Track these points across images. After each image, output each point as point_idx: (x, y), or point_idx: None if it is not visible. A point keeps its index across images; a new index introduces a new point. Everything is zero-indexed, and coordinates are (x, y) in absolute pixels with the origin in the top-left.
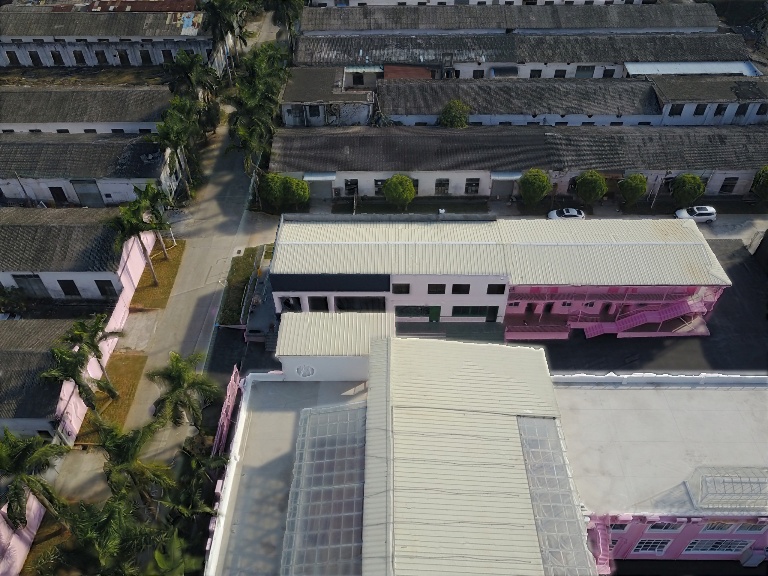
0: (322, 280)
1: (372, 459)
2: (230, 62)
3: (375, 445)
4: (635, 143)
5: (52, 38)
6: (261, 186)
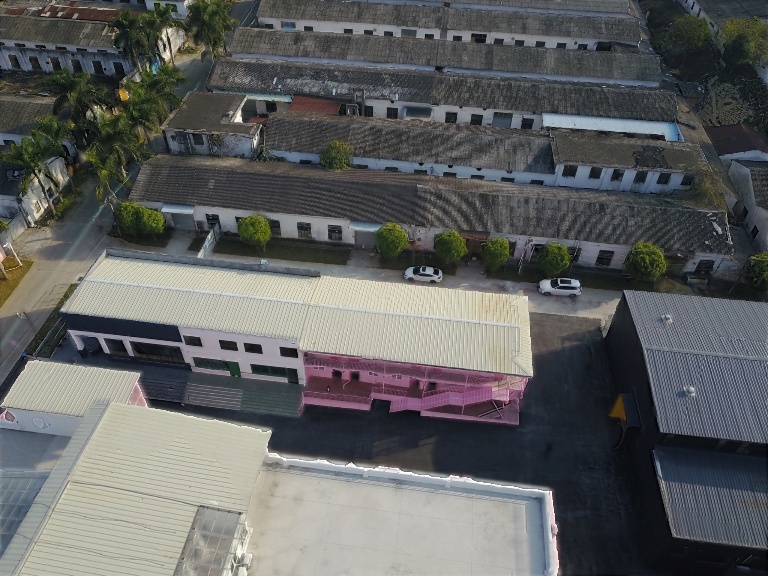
0: (112, 324)
1: (19, 538)
2: None
3: (30, 522)
4: (509, 204)
5: None
6: (116, 214)
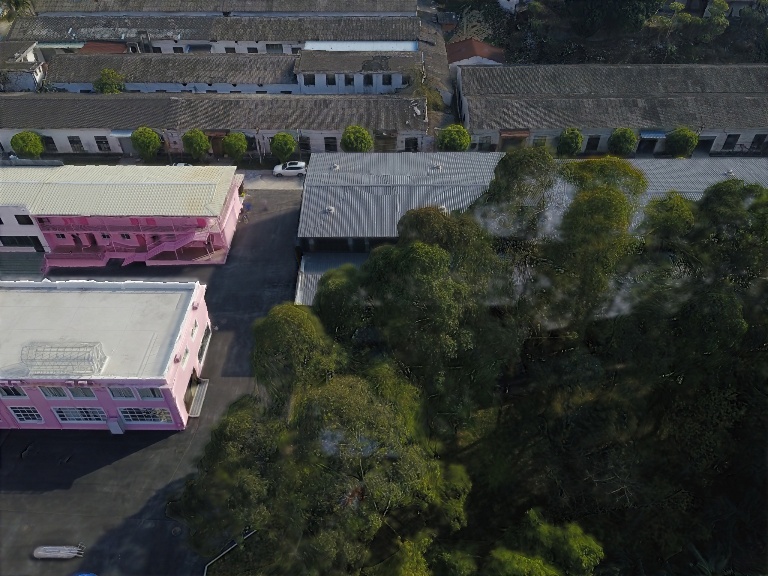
0: None
1: None
2: None
3: None
4: (248, 106)
5: None
6: None
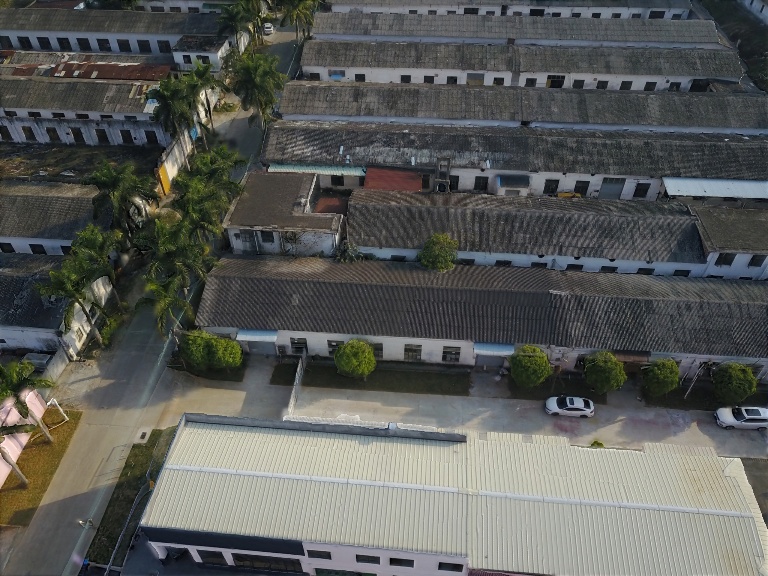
0: (211, 539)
1: None
2: (198, 145)
3: None
4: (667, 312)
5: (2, 110)
6: (181, 346)
